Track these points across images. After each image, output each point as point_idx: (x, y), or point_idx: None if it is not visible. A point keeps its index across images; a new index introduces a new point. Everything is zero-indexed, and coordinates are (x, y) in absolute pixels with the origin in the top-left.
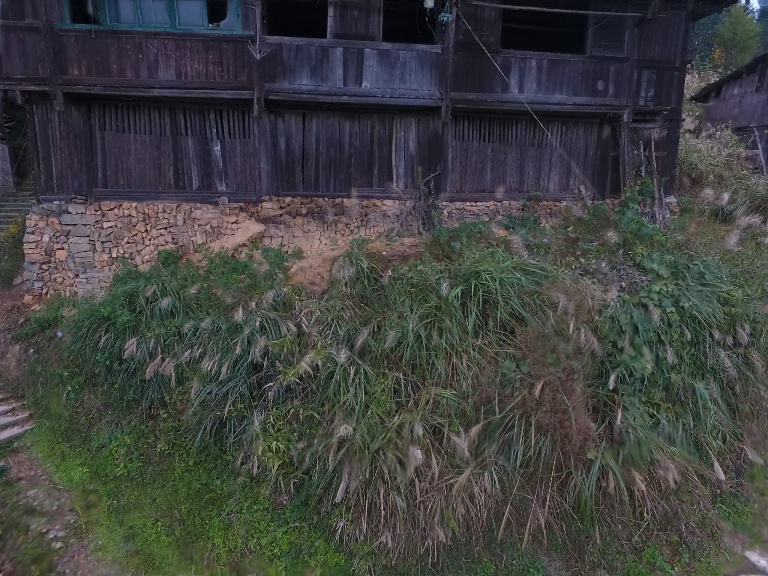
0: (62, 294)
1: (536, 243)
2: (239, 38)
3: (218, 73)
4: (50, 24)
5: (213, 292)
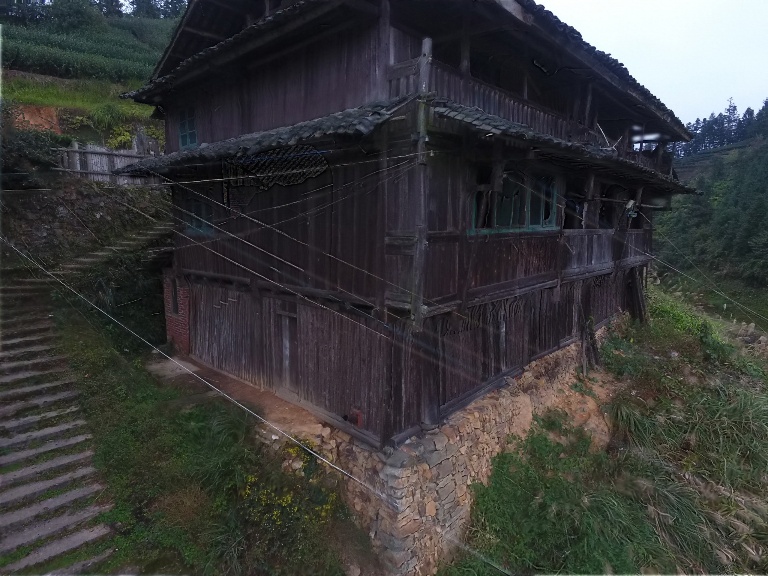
0: (430, 560)
1: (651, 360)
2: (556, 234)
3: (543, 266)
4: None
5: None
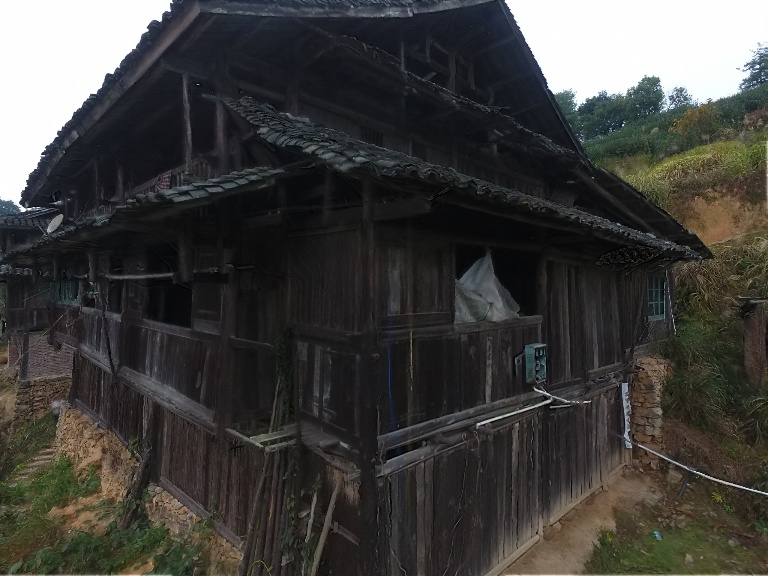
0: None
1: None
2: None
3: (75, 333)
4: (55, 302)
5: (0, 513)
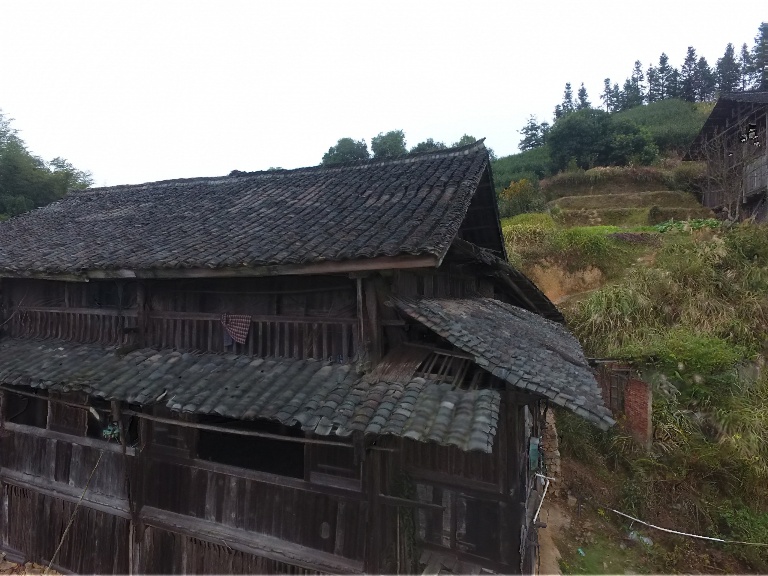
0: None
1: None
2: None
3: None
4: None
5: None
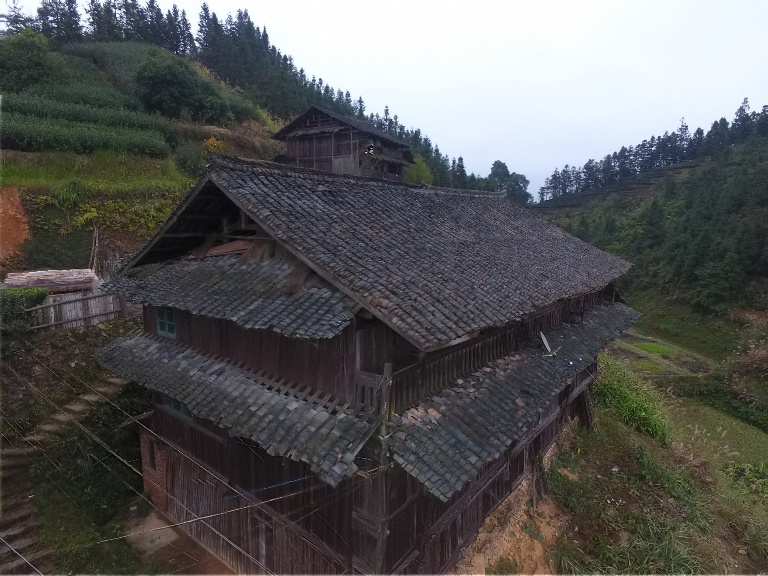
0: None
1: (594, 479)
2: None
3: None
4: (423, 492)
5: None
